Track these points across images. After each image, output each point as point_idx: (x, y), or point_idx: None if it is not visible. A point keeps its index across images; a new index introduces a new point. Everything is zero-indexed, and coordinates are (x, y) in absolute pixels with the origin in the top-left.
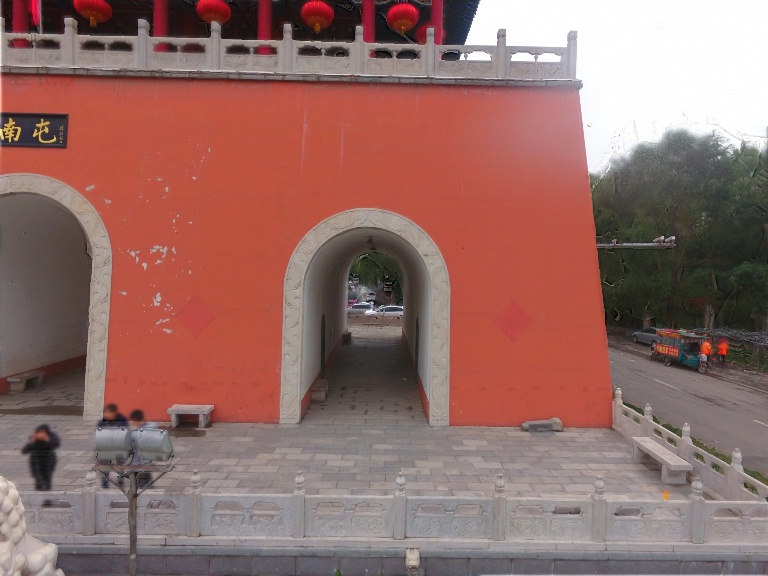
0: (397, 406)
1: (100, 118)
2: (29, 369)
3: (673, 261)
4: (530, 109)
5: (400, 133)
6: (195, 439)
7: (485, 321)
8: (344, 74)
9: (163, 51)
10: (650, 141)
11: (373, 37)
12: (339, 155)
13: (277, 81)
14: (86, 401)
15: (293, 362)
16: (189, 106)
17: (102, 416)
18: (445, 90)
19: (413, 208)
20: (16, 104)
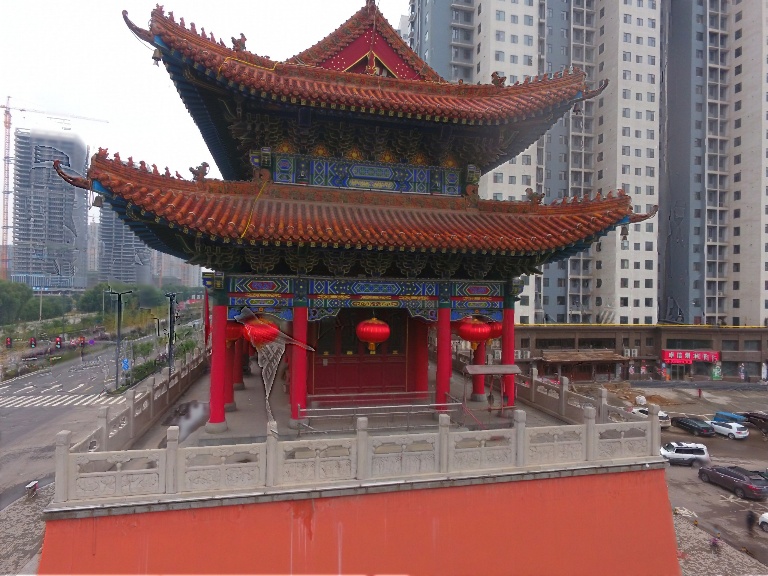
0: None
1: None
2: None
3: None
4: None
5: None
6: None
7: None
8: None
9: None
10: None
11: (226, 350)
12: None
13: None
14: None
15: None
16: None
17: None
18: None
19: None
20: None
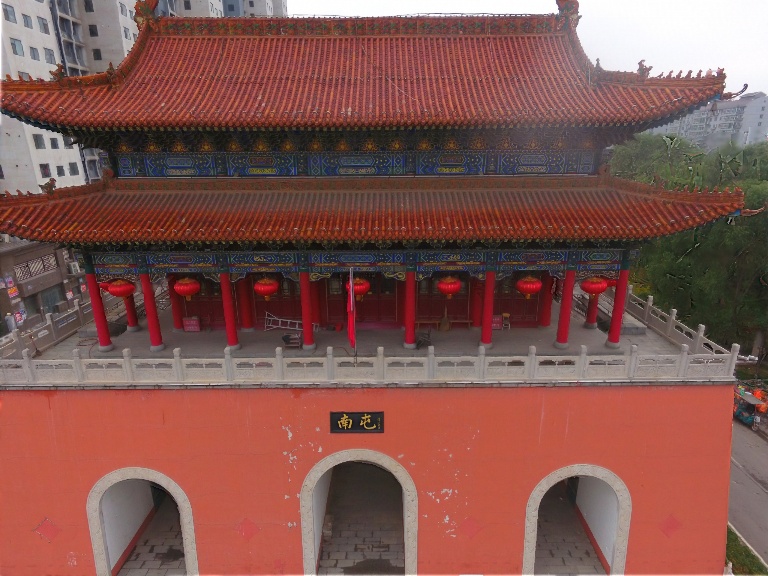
0: (578, 550)
1: (404, 412)
2: (324, 515)
3: (736, 299)
4: (698, 399)
5: (607, 417)
6: None
7: (651, 526)
8: (572, 381)
9: (444, 365)
10: (725, 149)
11: None
12: (565, 432)
13: None
14: (407, 574)
15: (531, 551)
16: (464, 404)
17: None
18: (641, 388)
19: (612, 462)
20: (348, 406)
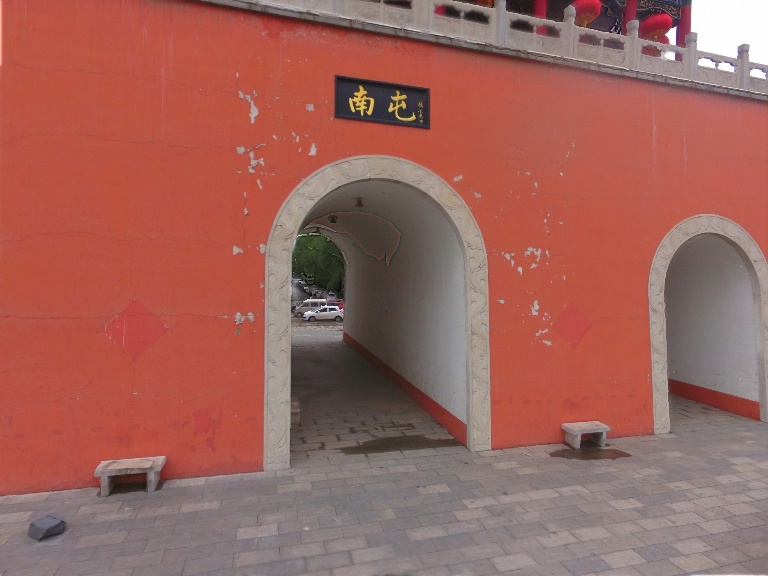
0: (691, 407)
1: (461, 97)
2: None
3: None
4: None
5: (729, 142)
6: (635, 459)
7: None
8: (686, 79)
9: (518, 29)
10: None
11: None
12: (684, 160)
13: (631, 78)
14: (472, 429)
15: (661, 370)
16: (552, 94)
17: (490, 444)
18: (758, 105)
19: (741, 216)
20: (368, 69)
